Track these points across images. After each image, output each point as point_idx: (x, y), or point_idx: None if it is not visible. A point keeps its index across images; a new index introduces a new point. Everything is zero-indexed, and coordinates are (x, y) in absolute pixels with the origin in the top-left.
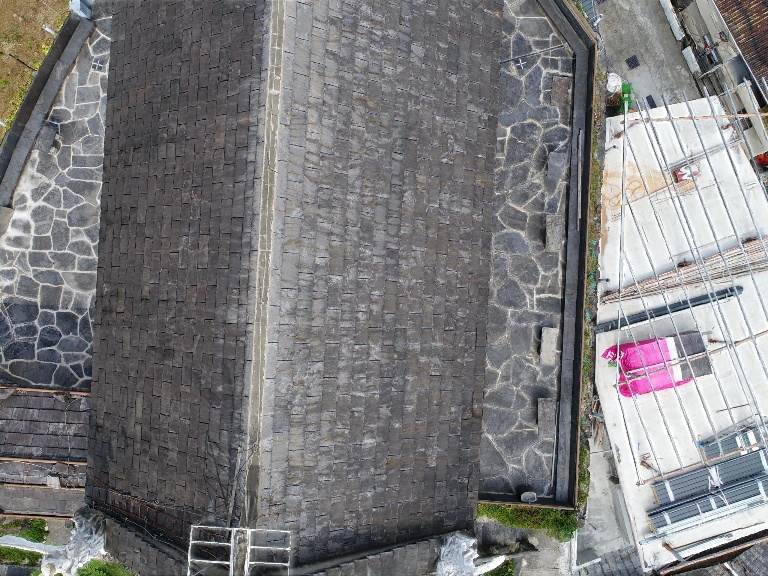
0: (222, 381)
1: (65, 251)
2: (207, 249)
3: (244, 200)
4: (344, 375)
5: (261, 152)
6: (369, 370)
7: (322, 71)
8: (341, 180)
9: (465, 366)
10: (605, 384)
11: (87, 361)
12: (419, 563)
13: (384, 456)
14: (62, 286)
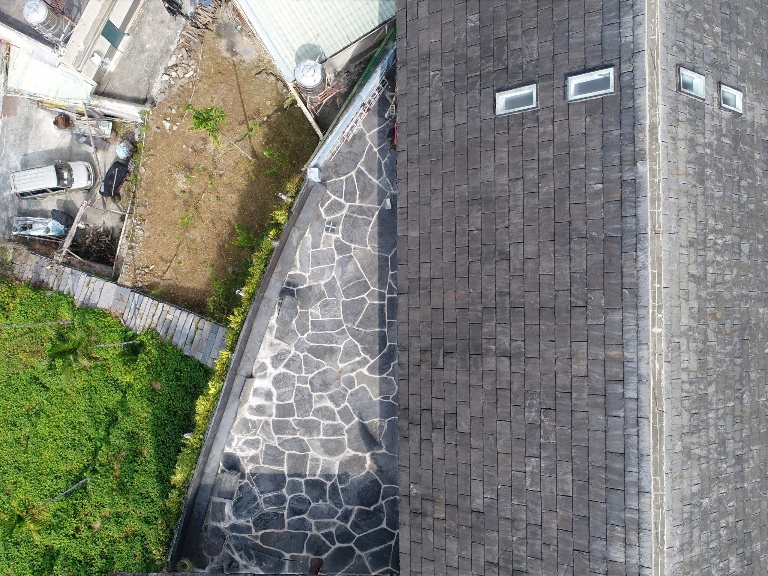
0: None
1: (309, 417)
2: (570, 477)
3: (624, 437)
4: None
5: (646, 392)
6: None
7: (687, 296)
8: (704, 401)
9: None
10: None
11: (338, 528)
12: None
13: None
14: (308, 453)
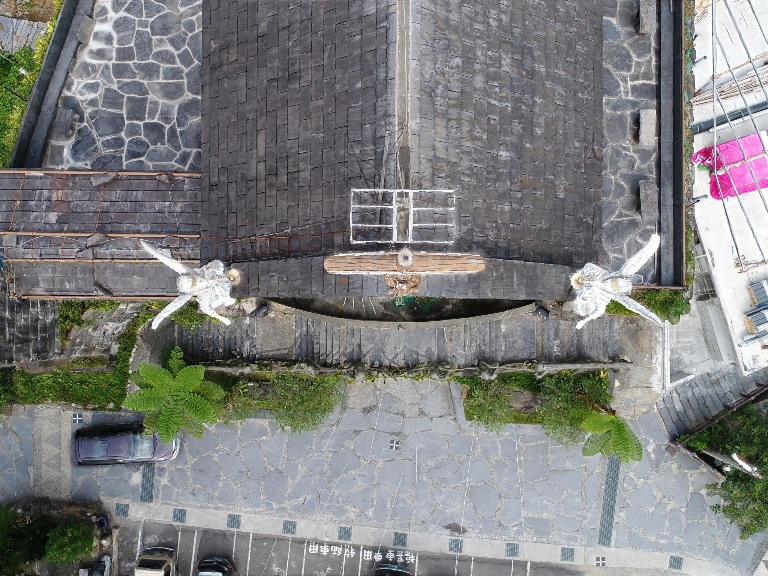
0: (361, 76)
1: (149, 61)
2: None
3: None
4: (480, 78)
5: None
6: (501, 80)
7: None
8: None
9: (585, 103)
10: (695, 188)
11: None
12: (556, 286)
13: (518, 173)
14: (148, 96)
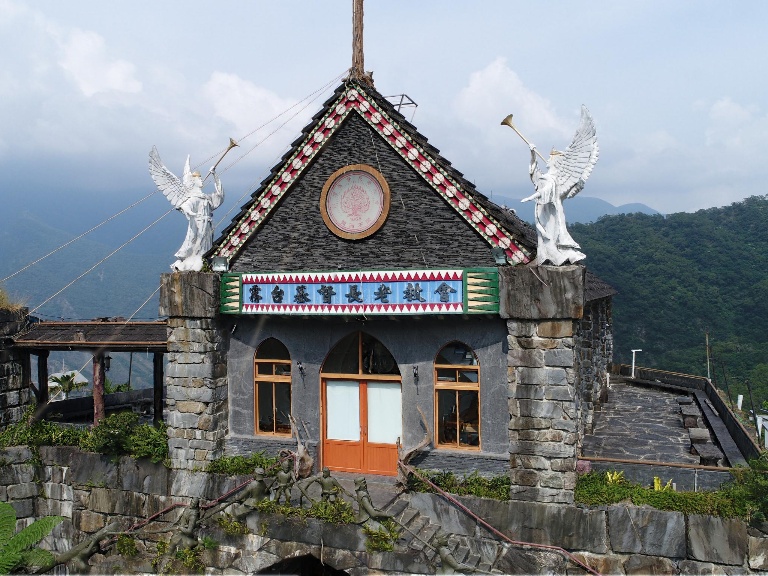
0: None
1: None
2: None
3: None
4: None
5: None
6: None
7: None
8: None
9: None
10: None
11: None
12: None
13: None
14: None
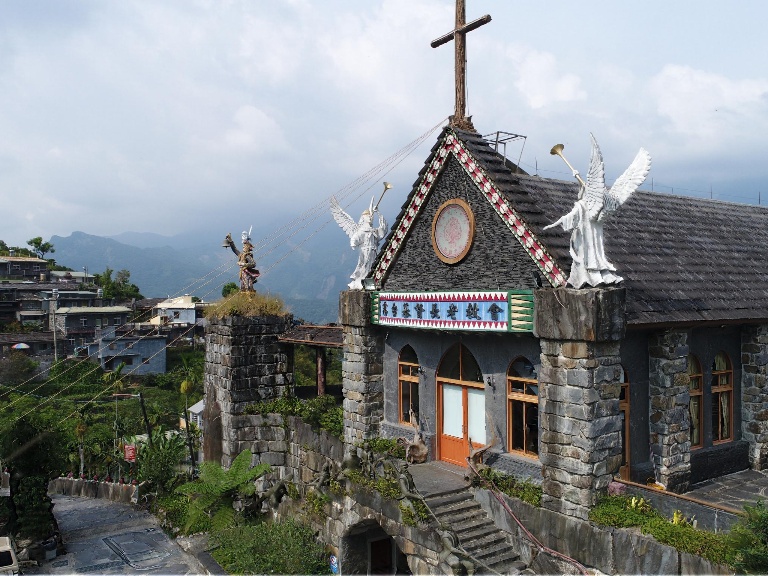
0: None
1: None
2: None
3: None
4: None
5: None
6: None
7: None
8: None
9: None
10: None
11: None
12: None
13: None
14: None
